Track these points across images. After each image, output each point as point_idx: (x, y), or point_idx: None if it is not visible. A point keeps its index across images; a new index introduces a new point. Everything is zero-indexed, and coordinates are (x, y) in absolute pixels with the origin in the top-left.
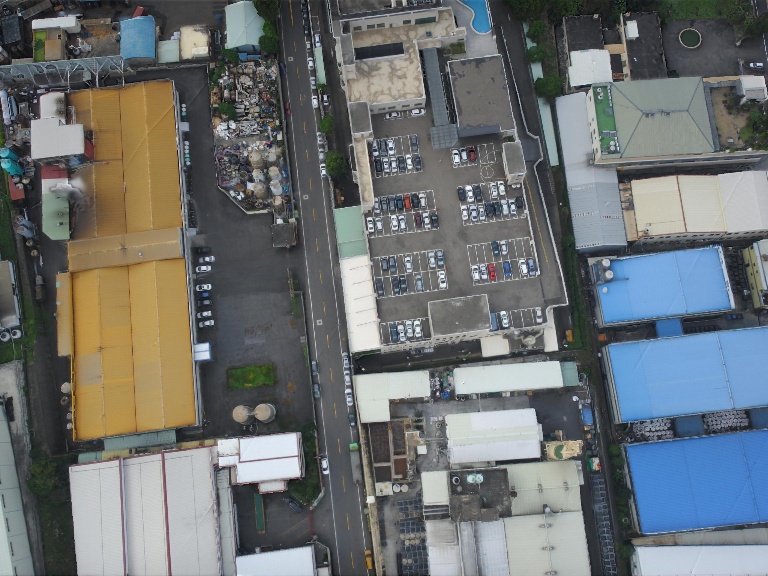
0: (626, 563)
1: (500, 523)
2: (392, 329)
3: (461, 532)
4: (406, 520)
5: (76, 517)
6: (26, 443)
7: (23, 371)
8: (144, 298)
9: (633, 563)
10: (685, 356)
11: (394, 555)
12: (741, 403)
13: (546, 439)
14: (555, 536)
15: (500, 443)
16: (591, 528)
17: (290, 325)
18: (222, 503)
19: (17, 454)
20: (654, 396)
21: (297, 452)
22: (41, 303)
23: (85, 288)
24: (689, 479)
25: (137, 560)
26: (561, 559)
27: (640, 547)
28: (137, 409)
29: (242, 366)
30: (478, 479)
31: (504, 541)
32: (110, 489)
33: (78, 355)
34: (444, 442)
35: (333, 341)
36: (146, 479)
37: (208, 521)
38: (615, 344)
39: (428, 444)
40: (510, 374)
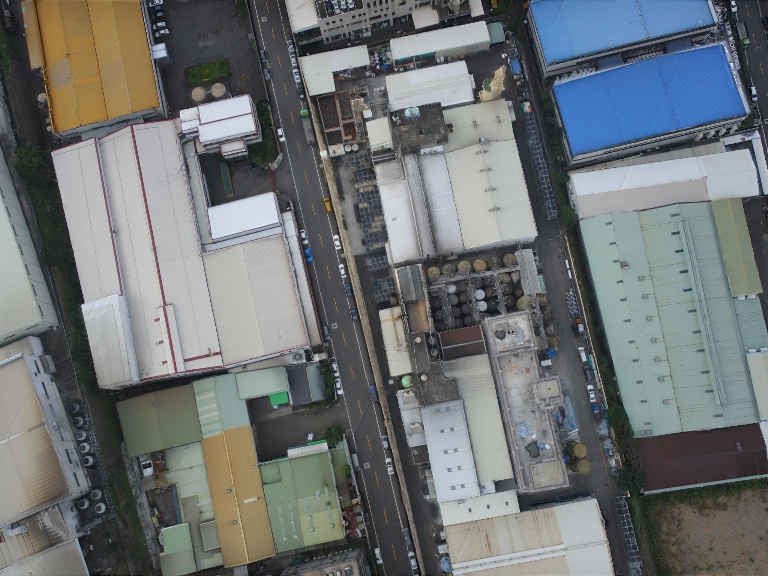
0: (563, 192)
1: (442, 159)
2: (327, 4)
3: (406, 166)
4: (358, 172)
5: (63, 191)
6: (12, 140)
7: (2, 85)
8: (101, 9)
9: (570, 192)
10: (600, 1)
11: (352, 207)
12: (654, 33)
13: (479, 91)
14: (491, 160)
15: (435, 92)
16: (527, 162)
17: (238, 26)
18: (191, 169)
19: (5, 149)
20: (575, 40)
21: (250, 110)
22: (12, 34)
23: (48, 8)
24: (612, 104)
25: (120, 218)
26: (498, 178)
27: (574, 174)
28: (106, 102)
29: (198, 65)
30: (414, 109)
31: (447, 173)
32: (89, 163)
33: (49, 65)
34: (387, 106)
35: (278, 33)
36: (120, 150)
37: (179, 179)
38: (536, 1)
39: (374, 112)
40: (441, 39)
